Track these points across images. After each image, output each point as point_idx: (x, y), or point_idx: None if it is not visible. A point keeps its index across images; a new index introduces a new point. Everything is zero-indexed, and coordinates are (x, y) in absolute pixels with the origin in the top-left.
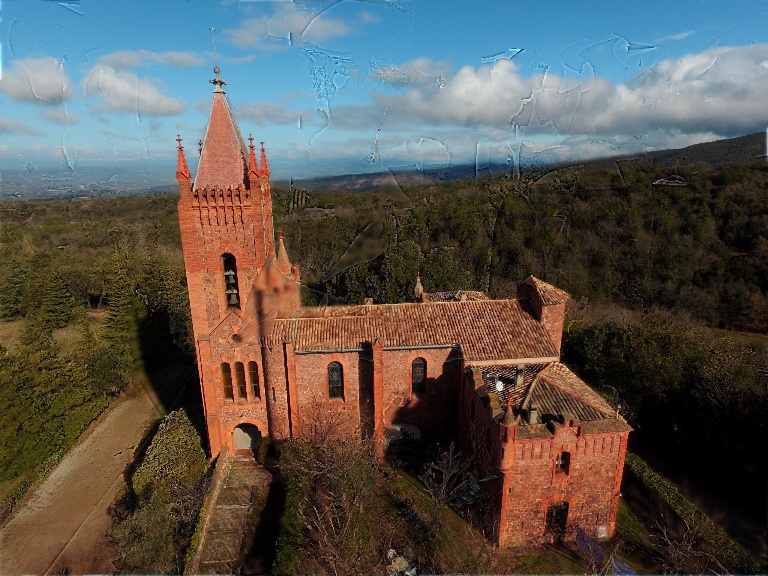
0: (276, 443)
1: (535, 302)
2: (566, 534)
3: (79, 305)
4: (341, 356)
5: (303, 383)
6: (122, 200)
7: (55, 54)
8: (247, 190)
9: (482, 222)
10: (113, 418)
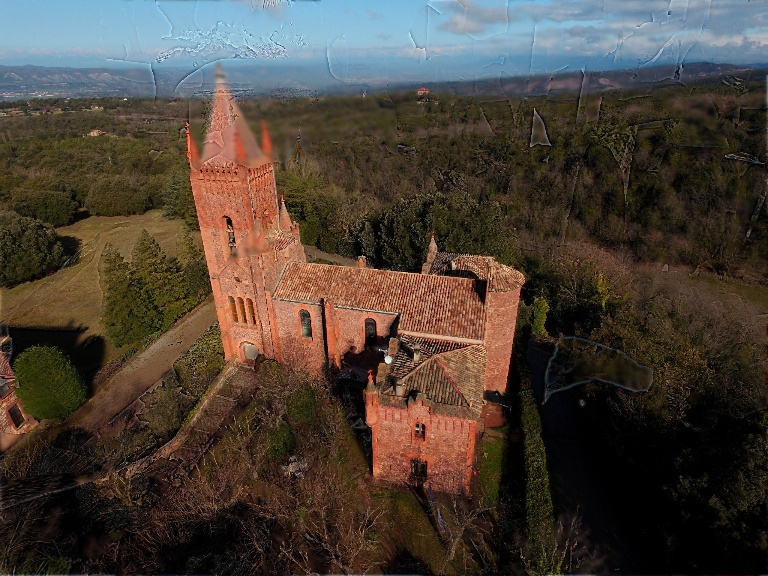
0: None
1: (486, 286)
2: (428, 483)
3: None
4: (308, 306)
5: (282, 321)
6: None
7: None
8: (236, 168)
9: None
10: (201, 313)
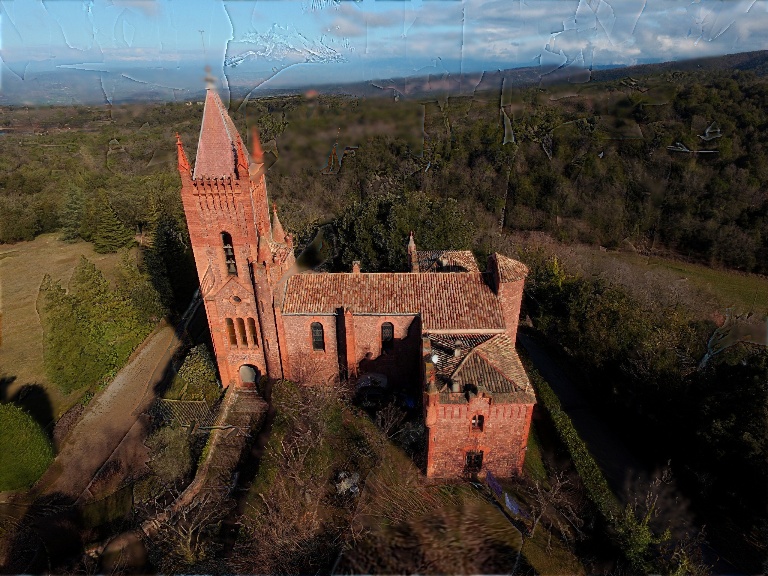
0: (272, 381)
1: (496, 277)
2: (482, 472)
3: (128, 232)
4: (321, 318)
5: (291, 337)
6: (153, 147)
7: None
8: (237, 180)
9: (505, 161)
10: (155, 342)
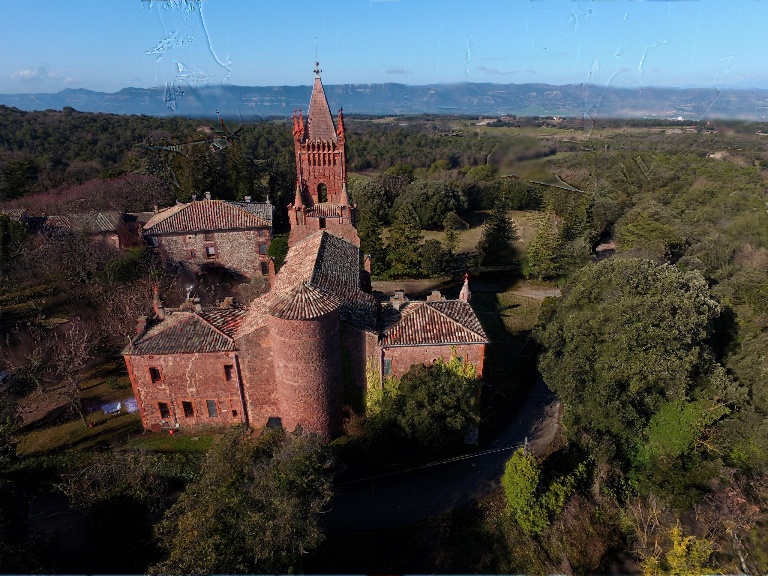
0: None
1: None
2: None
3: None
4: None
5: None
6: None
7: (583, 10)
8: None
9: None
10: None
